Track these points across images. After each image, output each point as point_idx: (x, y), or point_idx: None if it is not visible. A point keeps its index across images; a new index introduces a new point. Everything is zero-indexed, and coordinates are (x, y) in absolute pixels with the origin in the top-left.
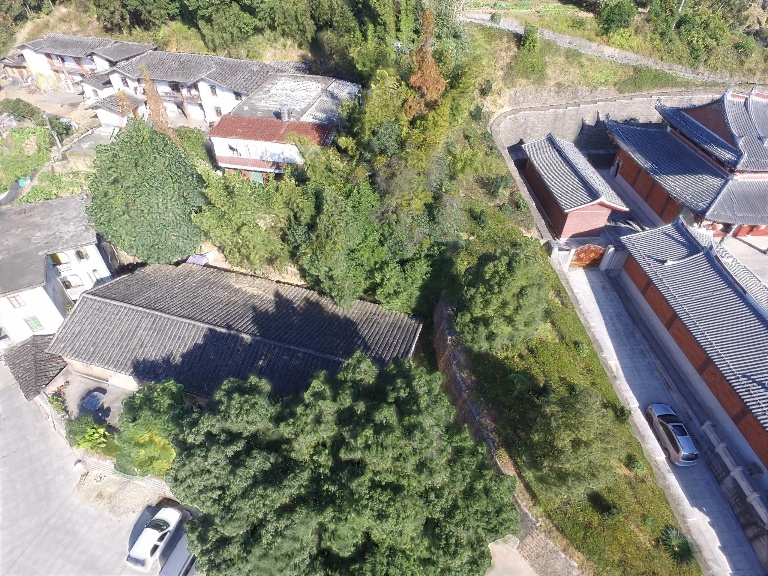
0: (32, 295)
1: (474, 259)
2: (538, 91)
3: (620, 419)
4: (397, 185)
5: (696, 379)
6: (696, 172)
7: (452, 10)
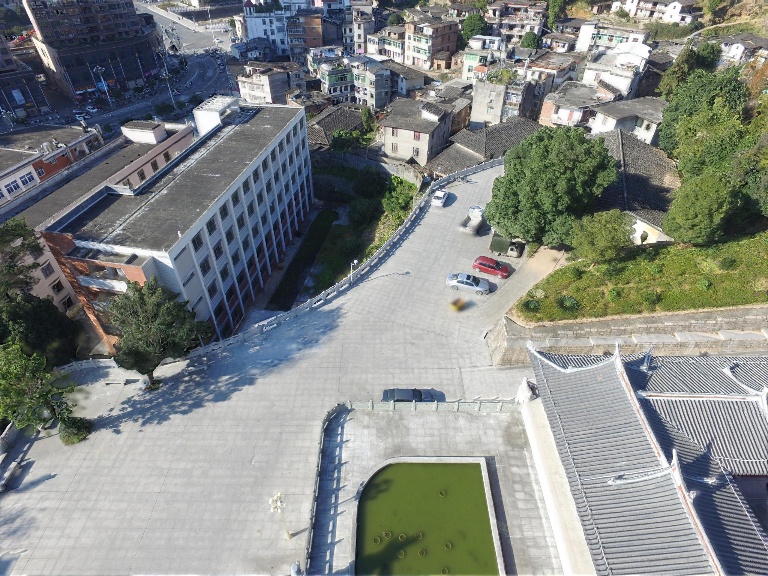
0: (611, 121)
1: (767, 236)
2: None
3: None
4: (761, 138)
5: None
6: None
7: None
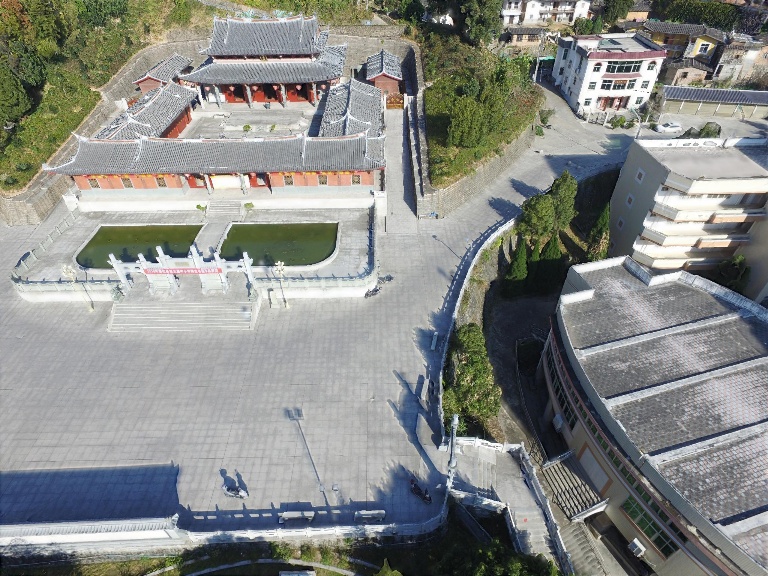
0: None
1: None
2: (184, 31)
3: (48, 141)
4: None
5: None
6: None
7: None
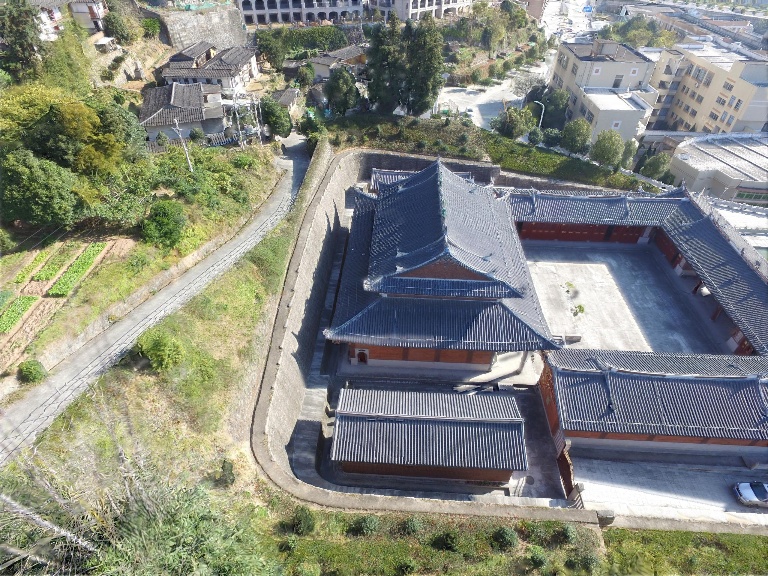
0: None
1: None
2: (240, 387)
3: None
4: None
5: (701, 447)
6: (473, 315)
7: (180, 509)
